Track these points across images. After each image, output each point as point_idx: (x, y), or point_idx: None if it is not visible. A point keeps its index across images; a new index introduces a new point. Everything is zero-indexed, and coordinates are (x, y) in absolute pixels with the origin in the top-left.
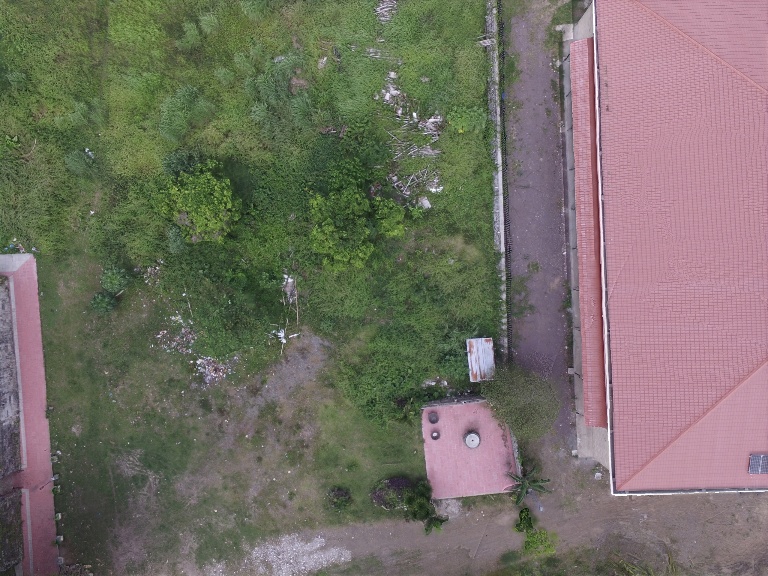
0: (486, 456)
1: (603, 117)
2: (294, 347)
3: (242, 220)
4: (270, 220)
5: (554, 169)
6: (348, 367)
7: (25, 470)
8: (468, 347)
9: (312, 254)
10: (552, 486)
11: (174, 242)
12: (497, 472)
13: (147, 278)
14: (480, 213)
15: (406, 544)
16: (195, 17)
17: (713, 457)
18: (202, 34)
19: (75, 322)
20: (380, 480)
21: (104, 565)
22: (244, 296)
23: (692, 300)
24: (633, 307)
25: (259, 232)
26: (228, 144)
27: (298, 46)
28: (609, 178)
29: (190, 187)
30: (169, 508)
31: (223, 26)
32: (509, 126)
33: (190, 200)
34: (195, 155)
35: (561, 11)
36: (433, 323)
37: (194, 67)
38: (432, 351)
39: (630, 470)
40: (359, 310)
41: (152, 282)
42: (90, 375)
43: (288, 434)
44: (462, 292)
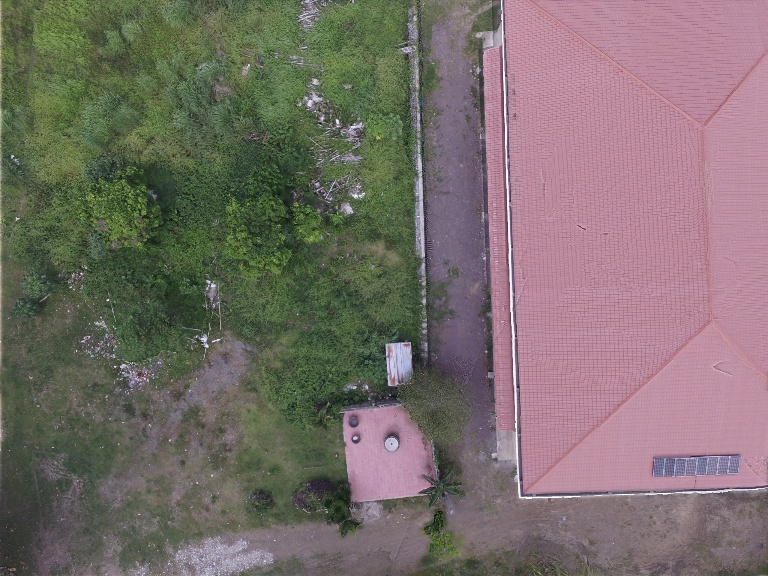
0: (406, 459)
1: (511, 124)
2: (217, 352)
3: (165, 226)
4: (193, 226)
5: (474, 175)
6: (269, 372)
7: None
8: (387, 352)
9: (234, 260)
10: (472, 489)
11: (95, 248)
12: (417, 475)
13: (71, 284)
14: (402, 219)
15: (327, 546)
16: (120, 24)
17: (617, 460)
18: (126, 41)
19: None
20: (302, 483)
21: (28, 568)
22: (167, 301)
23: (599, 305)
24: (543, 312)
25: (182, 238)
26: (150, 151)
27: (222, 53)
28: (517, 185)
29: (104, 194)
30: (93, 512)
31: (147, 33)
32: (429, 132)
33: (103, 207)
34: (118, 162)
35: (481, 18)
36: (354, 328)
37: (119, 74)
38: (352, 356)
39: (536, 473)
40: (280, 315)
41: (76, 288)
42: (15, 380)
43: (211, 438)
44: (382, 297)
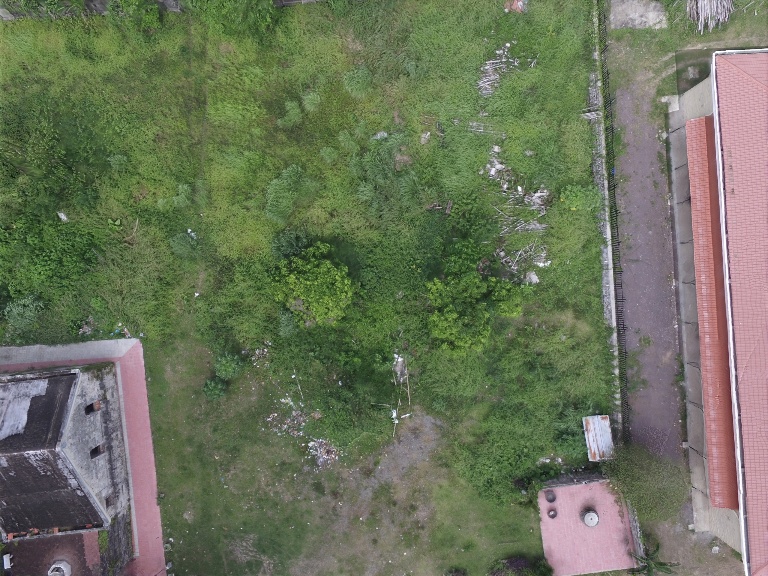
0: (603, 533)
1: (729, 200)
2: (406, 427)
3: (351, 300)
4: (379, 299)
5: (663, 242)
6: (463, 447)
7: (137, 559)
8: (584, 425)
9: (423, 334)
10: (669, 561)
11: (286, 327)
12: (614, 549)
13: (255, 360)
14: (589, 287)
15: None
16: (295, 94)
17: None
18: (304, 112)
19: (183, 407)
20: (497, 560)
21: None
22: (355, 377)
23: None
24: (760, 388)
25: (368, 312)
26: (335, 224)
27: (400, 121)
28: (736, 261)
29: (311, 277)
30: None
31: (324, 102)
32: (617, 199)
33: (313, 292)
34: (302, 235)
35: (666, 82)
36: (547, 400)
37: (296, 144)
38: (547, 429)
39: (766, 556)
40: (472, 389)
41: (261, 365)
42: (200, 460)
43: (402, 515)
44: (576, 369)
